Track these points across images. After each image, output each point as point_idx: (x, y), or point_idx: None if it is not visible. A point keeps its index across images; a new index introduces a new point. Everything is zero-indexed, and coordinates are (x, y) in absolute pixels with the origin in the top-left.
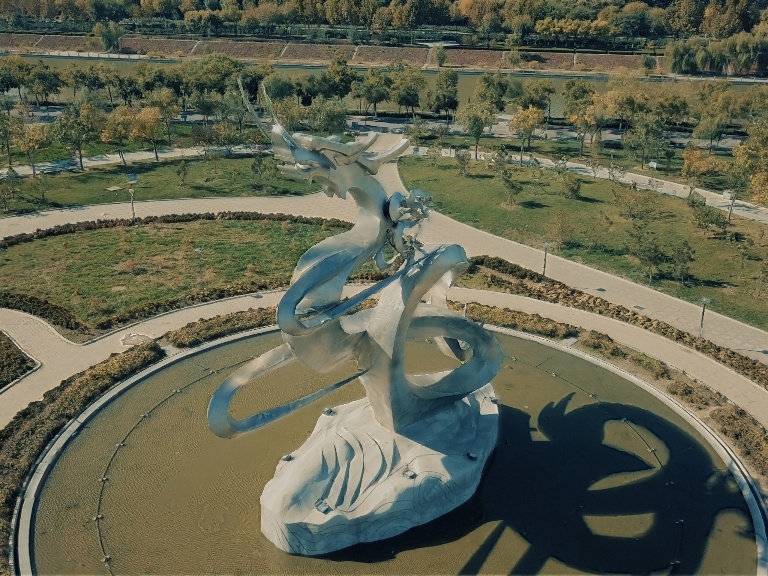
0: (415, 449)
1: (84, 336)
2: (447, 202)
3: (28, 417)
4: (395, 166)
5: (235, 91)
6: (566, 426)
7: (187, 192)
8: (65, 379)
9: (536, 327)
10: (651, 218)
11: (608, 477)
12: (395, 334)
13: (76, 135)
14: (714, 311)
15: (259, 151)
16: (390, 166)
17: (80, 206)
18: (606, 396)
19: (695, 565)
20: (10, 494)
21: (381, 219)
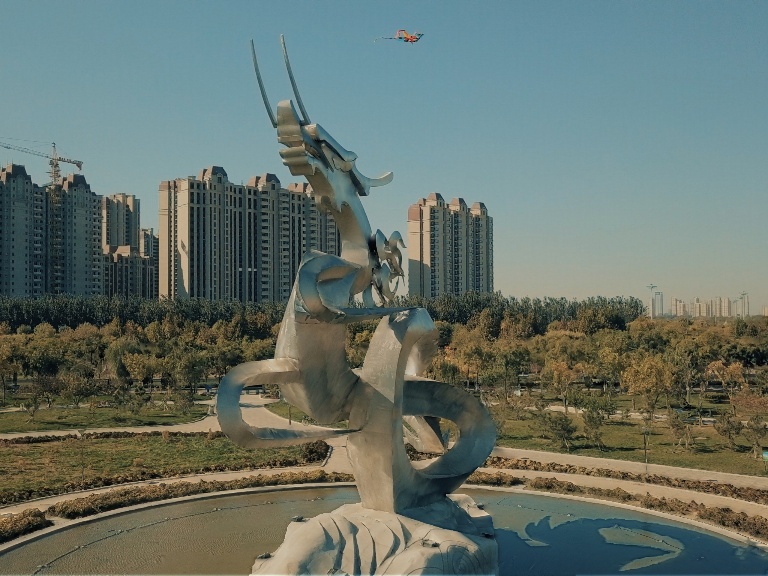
0: (424, 526)
1: None
2: None
3: None
4: (263, 408)
5: (77, 358)
6: (559, 537)
7: (38, 426)
8: None
9: (480, 477)
10: None
11: (633, 561)
12: (395, 374)
13: None
14: (642, 462)
15: (110, 404)
16: (258, 409)
17: None
18: (584, 515)
19: None
20: None
21: None
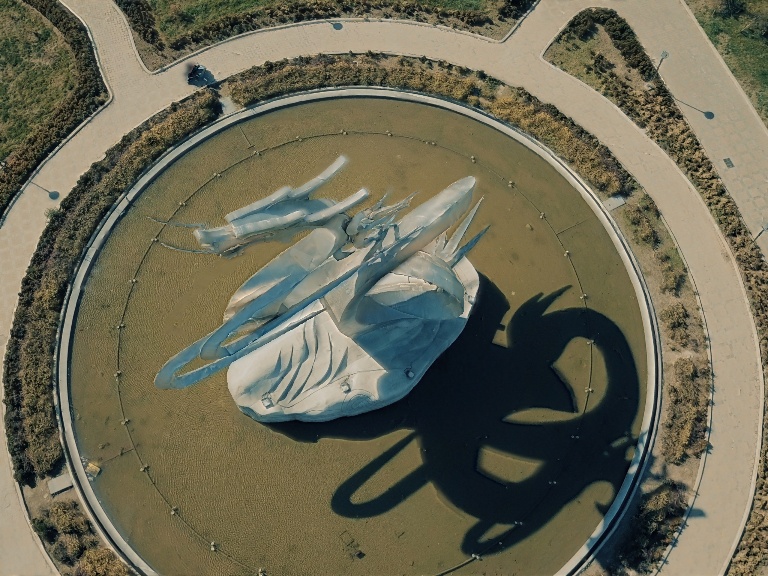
0: (362, 361)
1: (157, 57)
2: None
3: (88, 184)
4: None
5: None
6: (535, 330)
7: None
8: (128, 129)
9: (589, 175)
10: None
11: (529, 410)
12: (343, 311)
13: None
14: None
15: None
16: None
17: None
18: (597, 301)
19: (534, 529)
20: (63, 282)
21: (339, 233)
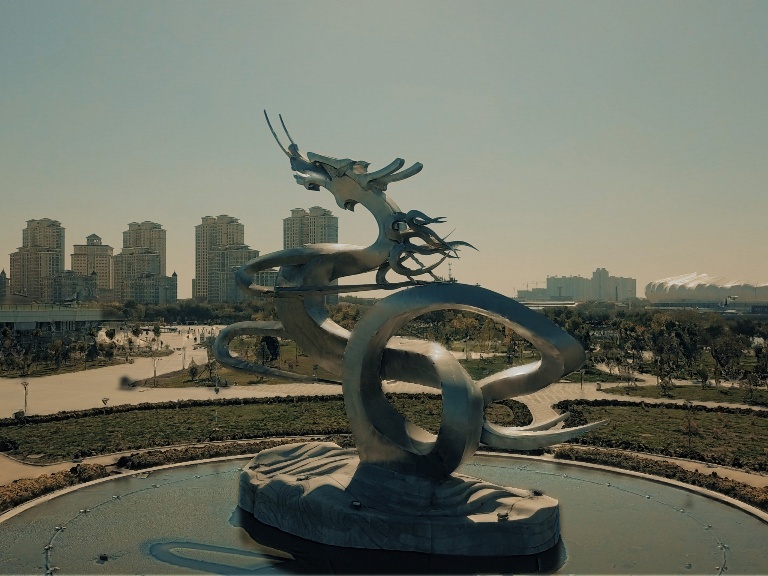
0: (343, 475)
1: None
2: None
3: None
4: None
5: None
6: None
7: None
8: None
9: None
10: None
11: None
12: None
13: None
14: None
15: None
16: None
17: None
18: None
19: None
20: None
21: (384, 236)
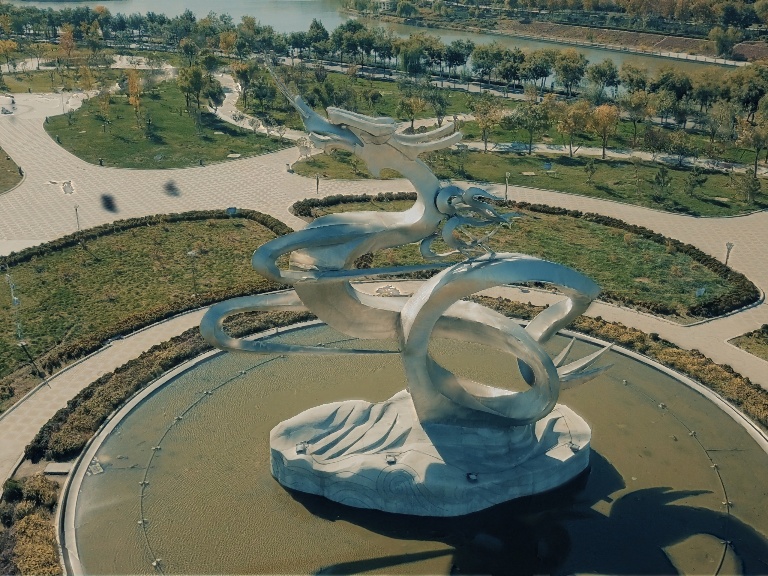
0: (422, 444)
1: None
2: None
3: (253, 314)
4: None
5: (737, 103)
6: (652, 515)
7: (586, 189)
8: None
9: (759, 413)
10: None
11: None
12: (413, 322)
13: (530, 121)
14: None
15: (713, 167)
16: None
17: (486, 182)
18: (746, 512)
19: None
20: (184, 355)
21: (430, 208)
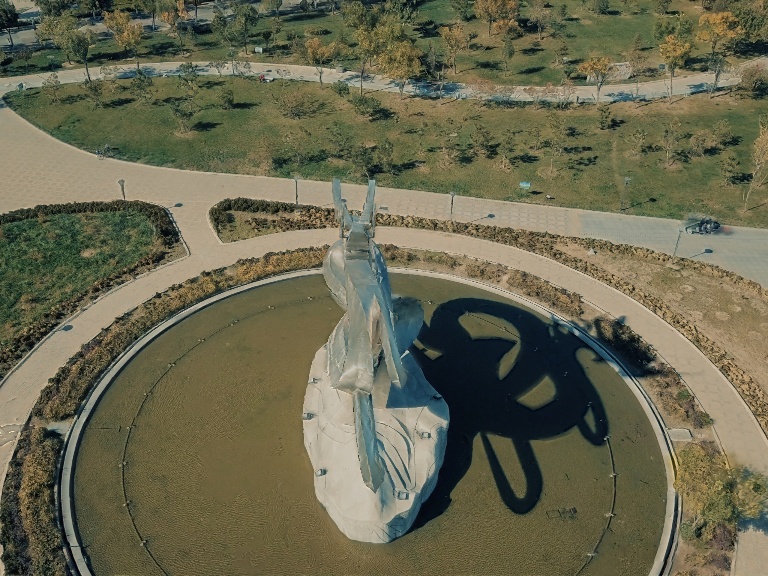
0: (408, 414)
1: None
2: (122, 146)
3: (21, 573)
4: (12, 112)
5: None
6: (438, 336)
7: None
8: None
9: None
10: (311, 112)
11: (501, 364)
12: None
13: None
14: (432, 192)
15: None
16: (6, 114)
17: None
18: (438, 298)
19: (598, 399)
20: None
21: None
